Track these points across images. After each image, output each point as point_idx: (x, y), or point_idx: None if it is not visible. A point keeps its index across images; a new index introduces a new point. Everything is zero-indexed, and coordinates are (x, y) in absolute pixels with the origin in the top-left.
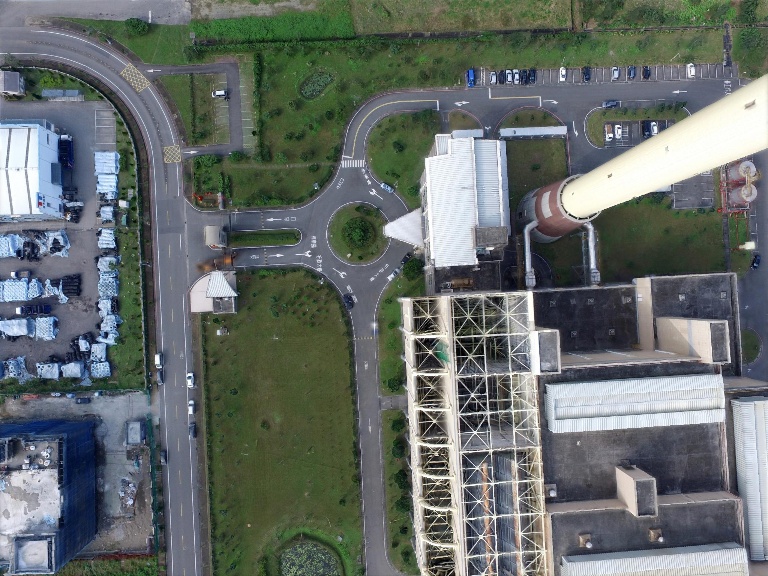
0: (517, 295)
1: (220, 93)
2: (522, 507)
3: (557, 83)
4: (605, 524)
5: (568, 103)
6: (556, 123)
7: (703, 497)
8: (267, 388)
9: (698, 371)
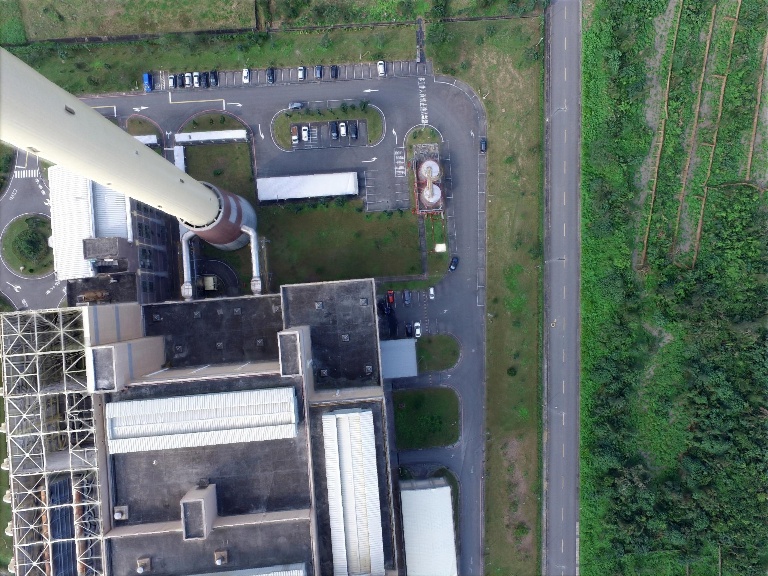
0: (72, 310)
1: None
2: (83, 531)
3: (241, 85)
4: (169, 547)
5: (253, 105)
6: (240, 126)
7: (277, 516)
8: None
9: (283, 384)
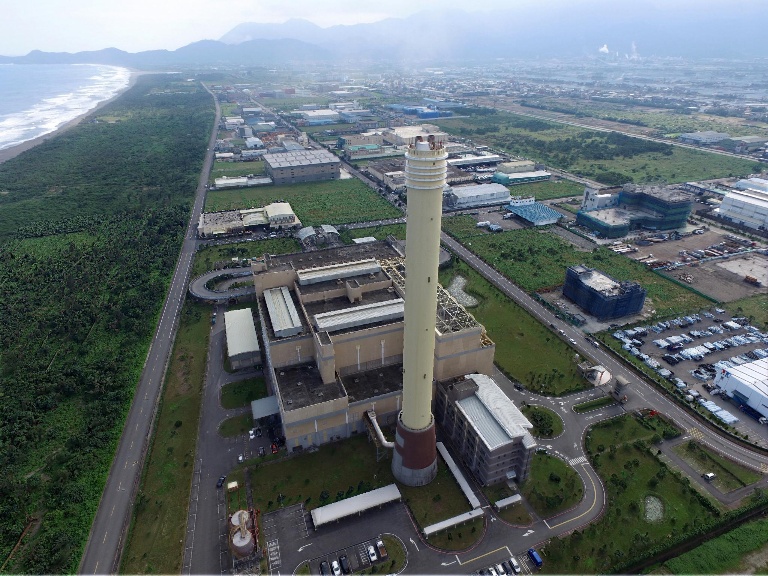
0: None
1: (710, 474)
2: None
3: None
4: None
5: (431, 568)
6: (435, 543)
7: (318, 296)
8: (532, 346)
9: None
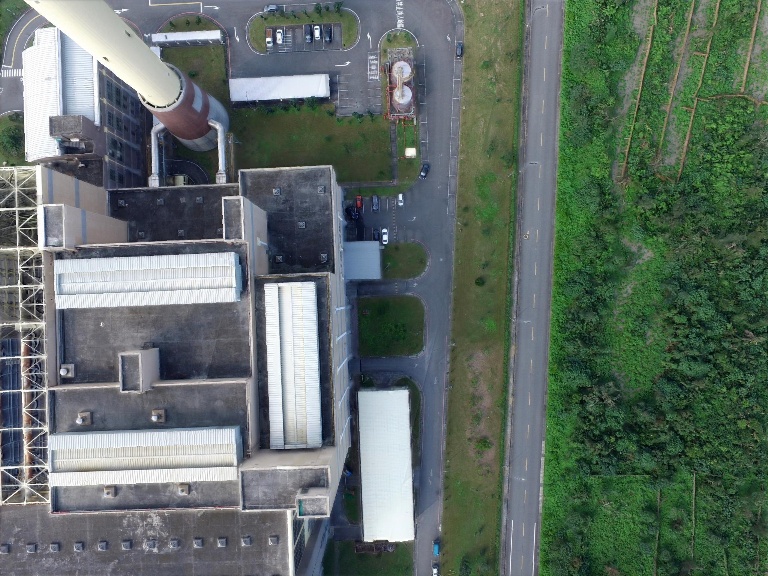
0: (27, 169)
1: None
2: None
3: None
4: (109, 403)
5: (230, 8)
6: (216, 29)
7: (215, 380)
8: None
9: None
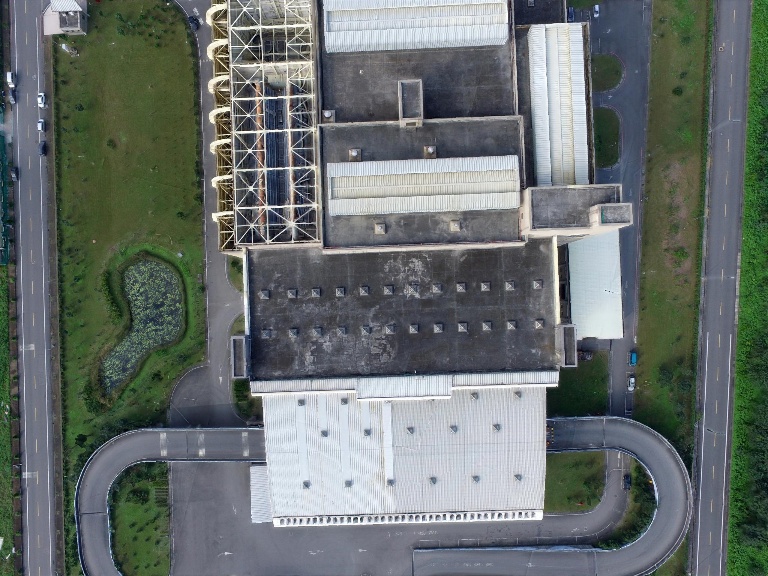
0: None
1: None
2: None
3: None
4: (378, 142)
5: None
6: None
7: None
8: (114, 108)
9: None
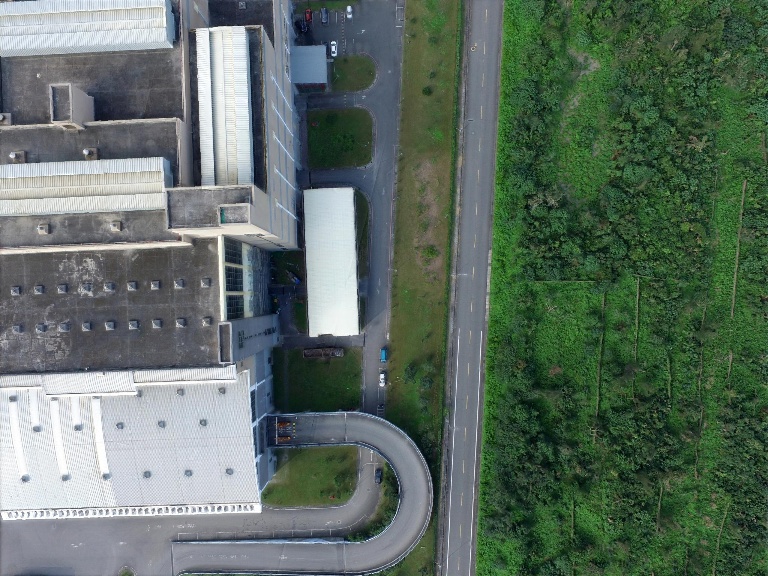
0: None
1: None
2: None
3: None
4: (44, 144)
5: None
6: None
7: None
8: None
9: None
